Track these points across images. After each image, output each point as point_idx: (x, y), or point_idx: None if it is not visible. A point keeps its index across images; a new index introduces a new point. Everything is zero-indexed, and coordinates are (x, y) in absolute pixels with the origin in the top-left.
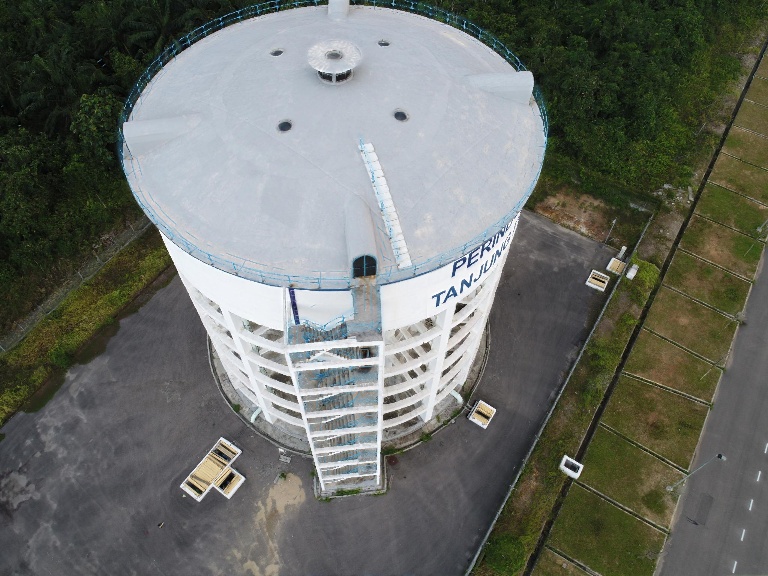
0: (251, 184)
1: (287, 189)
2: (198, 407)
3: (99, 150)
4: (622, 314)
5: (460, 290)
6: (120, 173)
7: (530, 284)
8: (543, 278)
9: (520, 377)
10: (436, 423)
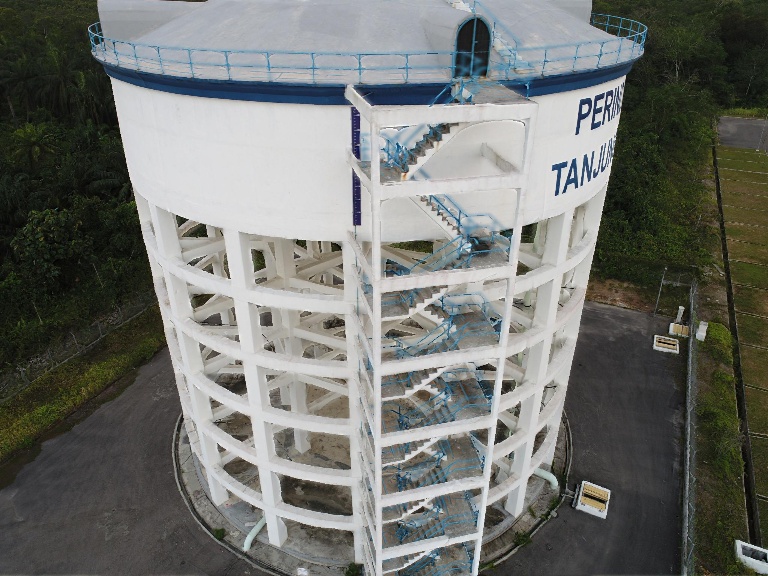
0: (282, 14)
1: (335, 11)
2: (156, 540)
3: (43, 265)
4: (712, 373)
5: (581, 178)
6: (65, 298)
7: (589, 354)
8: (601, 348)
9: (623, 450)
10: (530, 519)
